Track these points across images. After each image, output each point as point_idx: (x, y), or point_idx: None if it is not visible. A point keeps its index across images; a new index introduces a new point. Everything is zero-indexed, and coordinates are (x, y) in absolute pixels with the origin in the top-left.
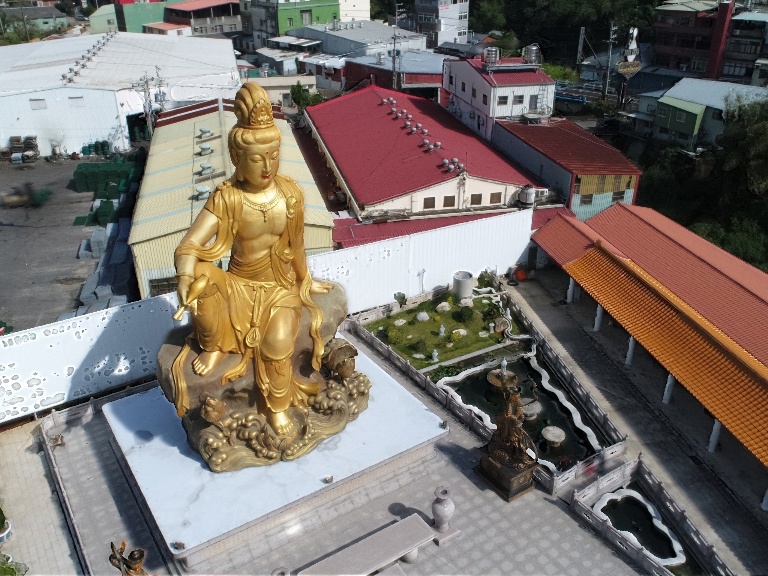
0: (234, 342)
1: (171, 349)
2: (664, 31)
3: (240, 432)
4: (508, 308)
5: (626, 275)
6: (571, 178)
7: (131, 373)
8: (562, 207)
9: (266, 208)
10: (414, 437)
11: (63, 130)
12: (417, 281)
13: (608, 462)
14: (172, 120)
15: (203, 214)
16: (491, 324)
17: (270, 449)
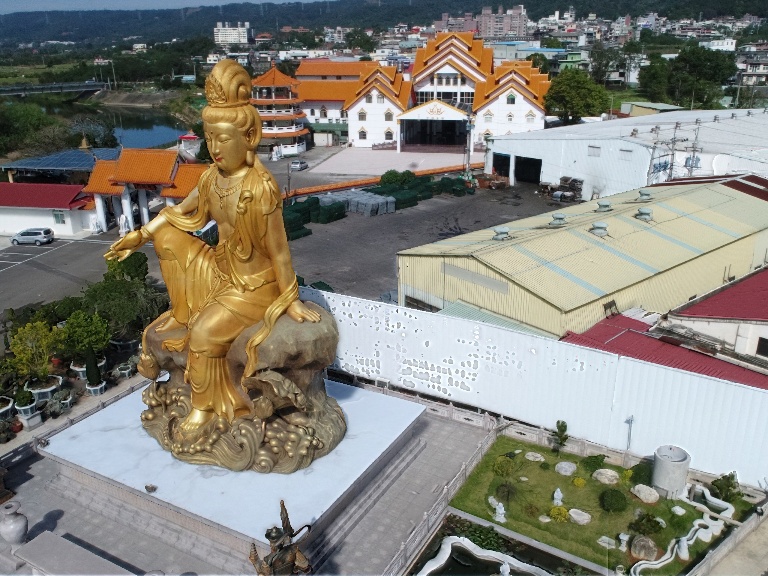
0: None
1: None
2: None
3: None
4: (684, 537)
5: None
6: None
7: None
8: None
9: (222, 194)
10: (252, 524)
11: (606, 180)
12: (625, 429)
13: None
14: (667, 184)
15: None
16: (621, 534)
17: None
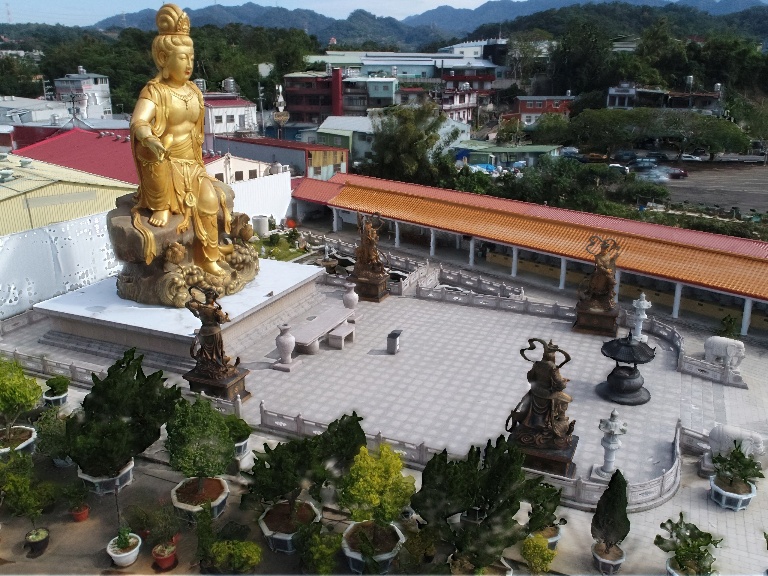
0: (176, 204)
1: (123, 218)
2: (294, 94)
3: (189, 279)
4: None
5: (377, 193)
6: (305, 154)
7: (20, 303)
8: (302, 178)
9: (187, 99)
10: (306, 273)
11: None
12: None
13: (422, 278)
14: None
15: (143, 102)
16: (296, 241)
17: (218, 285)
